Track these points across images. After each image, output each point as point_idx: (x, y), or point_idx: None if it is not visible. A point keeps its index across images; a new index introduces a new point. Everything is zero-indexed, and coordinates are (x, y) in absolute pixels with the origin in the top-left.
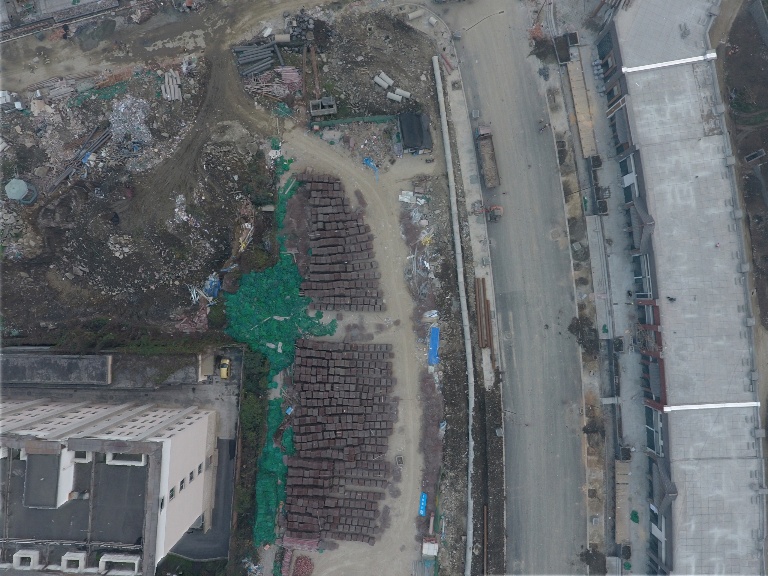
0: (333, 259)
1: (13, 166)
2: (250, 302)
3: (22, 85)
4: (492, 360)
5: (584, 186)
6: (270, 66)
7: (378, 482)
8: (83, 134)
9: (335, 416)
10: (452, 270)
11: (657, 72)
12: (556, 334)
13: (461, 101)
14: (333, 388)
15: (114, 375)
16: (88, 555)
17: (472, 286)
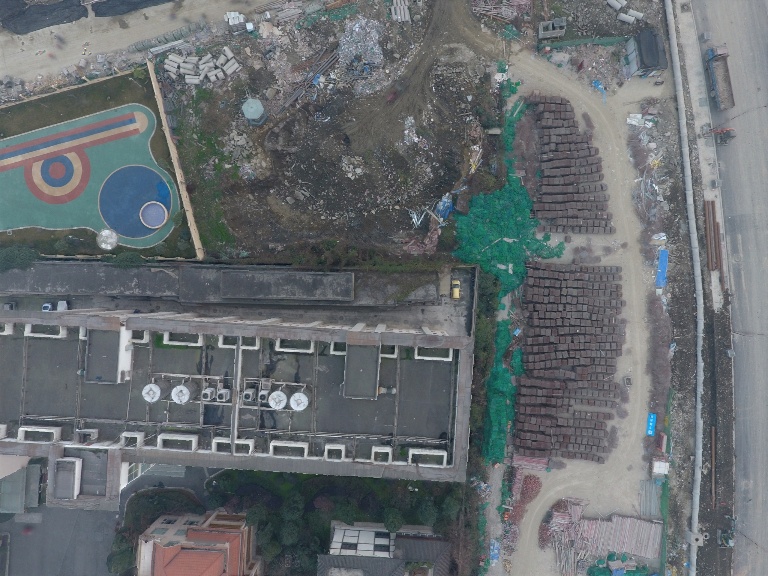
0: (566, 180)
1: (245, 87)
2: (482, 223)
3: (248, 7)
4: (722, 282)
5: None
6: None
7: (608, 402)
8: (310, 56)
9: (568, 336)
10: (681, 193)
11: None
12: None
13: (690, 23)
14: (565, 308)
15: (356, 292)
16: (394, 449)
17: (701, 209)
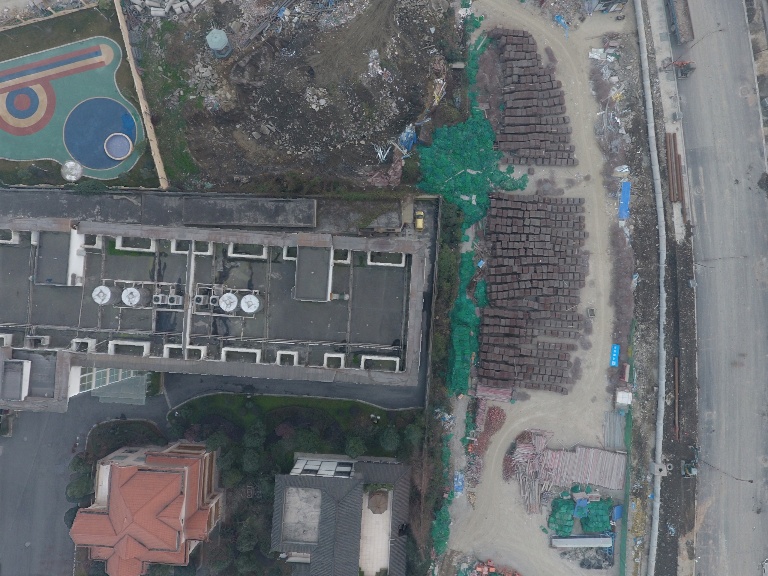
0: (529, 111)
1: (210, 19)
2: (446, 154)
3: None
4: (683, 214)
5: None
6: None
7: (571, 333)
8: None
9: (531, 266)
10: (642, 126)
11: None
12: (746, 189)
13: None
14: (528, 239)
15: (318, 220)
16: (347, 355)
17: (662, 141)
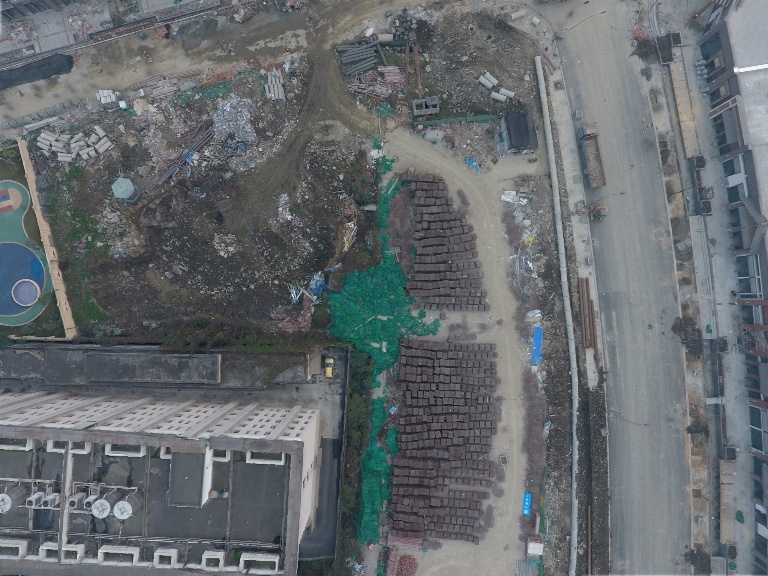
0: (438, 259)
1: (118, 165)
2: (355, 301)
3: (124, 84)
4: (596, 360)
5: (686, 186)
6: (373, 66)
7: (483, 481)
8: (186, 133)
9: (441, 415)
10: (555, 270)
11: (767, 72)
12: (659, 334)
13: (563, 101)
14: (438, 387)
15: (223, 374)
16: (227, 554)
17: (575, 286)
